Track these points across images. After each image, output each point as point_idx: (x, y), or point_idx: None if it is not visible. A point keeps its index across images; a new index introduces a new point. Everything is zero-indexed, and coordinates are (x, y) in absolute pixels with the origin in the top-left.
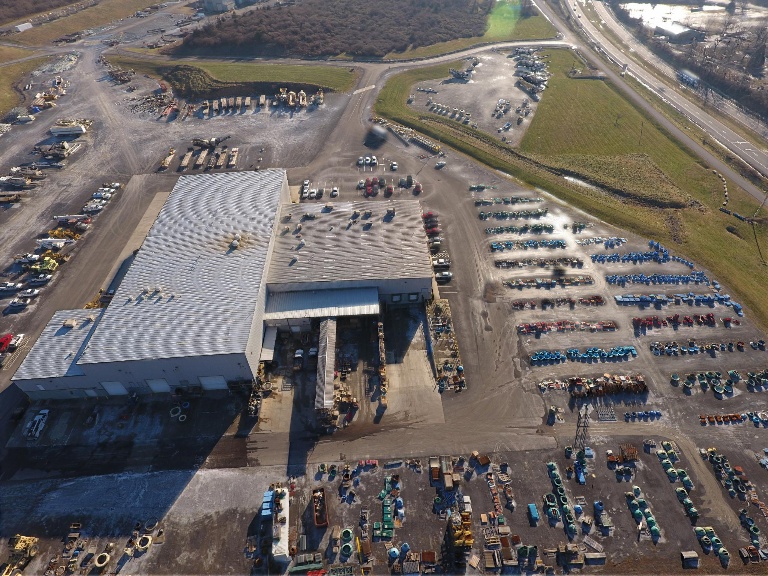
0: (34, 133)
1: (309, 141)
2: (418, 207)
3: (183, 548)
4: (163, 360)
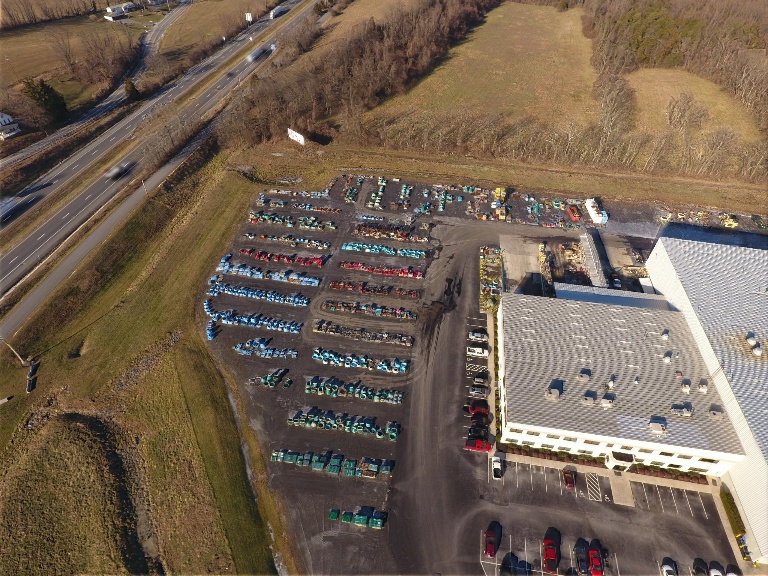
0: None
1: None
2: (510, 403)
3: (642, 215)
4: None
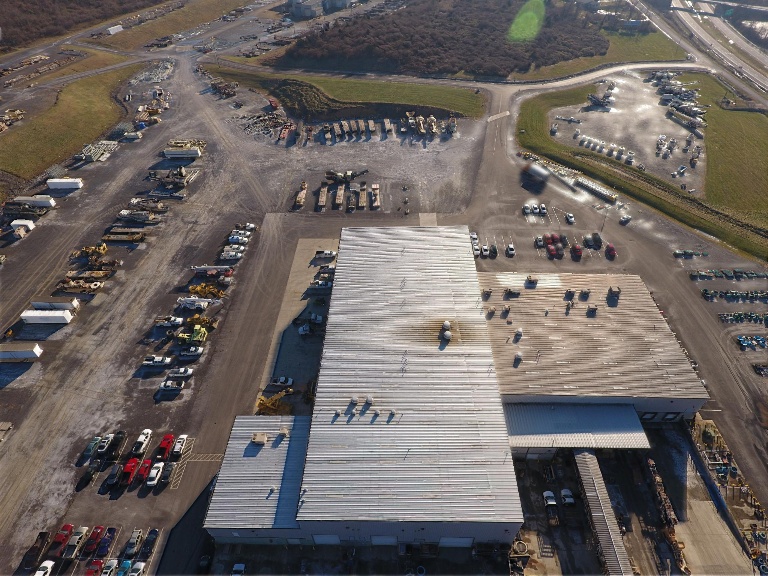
0: (144, 154)
1: (456, 179)
2: (643, 286)
3: None
4: (411, 522)
